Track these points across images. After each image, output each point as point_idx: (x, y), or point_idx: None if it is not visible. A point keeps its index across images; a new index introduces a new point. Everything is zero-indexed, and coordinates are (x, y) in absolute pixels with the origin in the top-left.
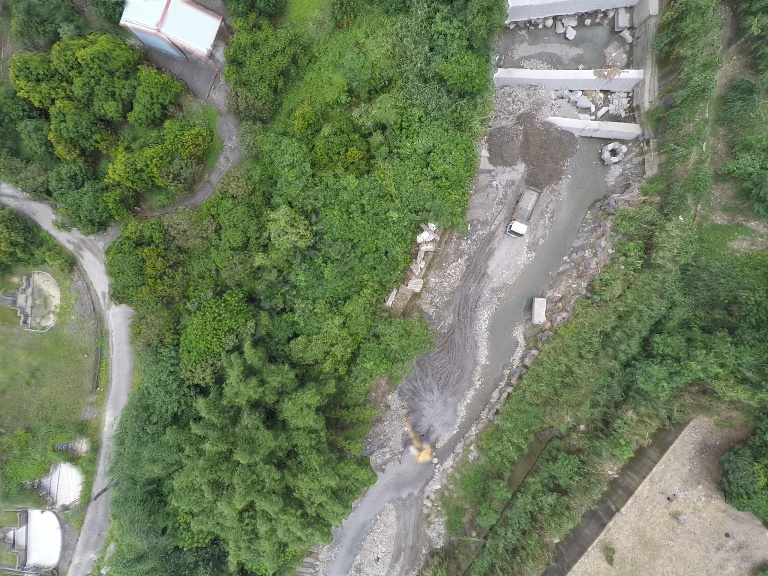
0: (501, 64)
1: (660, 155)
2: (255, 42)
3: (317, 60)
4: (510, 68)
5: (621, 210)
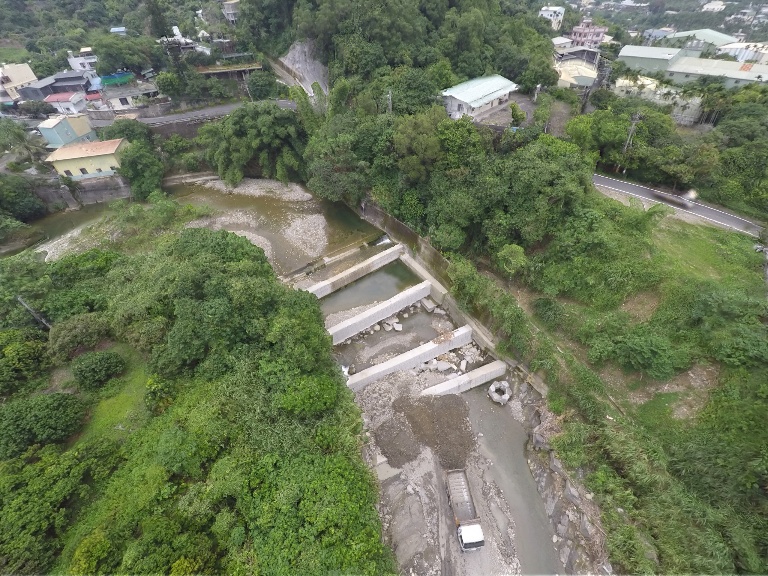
0: (354, 371)
1: (537, 374)
2: (19, 485)
3: (127, 463)
4: (362, 370)
5: (554, 442)
